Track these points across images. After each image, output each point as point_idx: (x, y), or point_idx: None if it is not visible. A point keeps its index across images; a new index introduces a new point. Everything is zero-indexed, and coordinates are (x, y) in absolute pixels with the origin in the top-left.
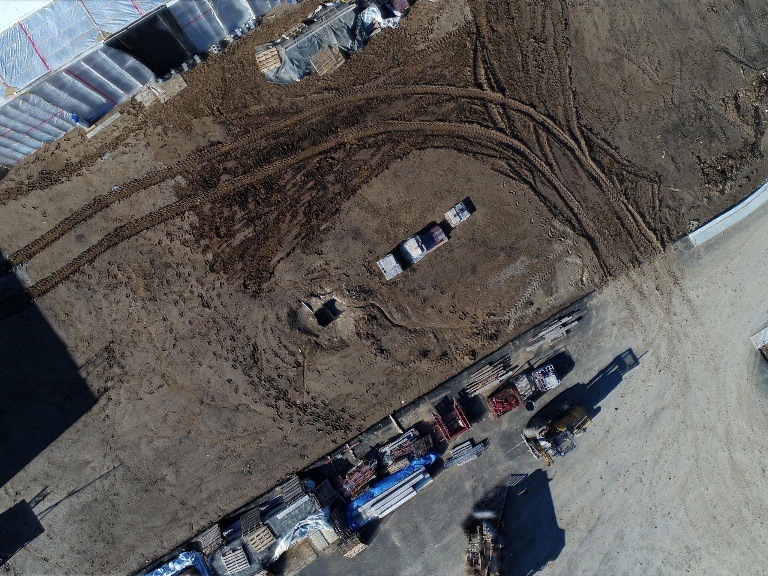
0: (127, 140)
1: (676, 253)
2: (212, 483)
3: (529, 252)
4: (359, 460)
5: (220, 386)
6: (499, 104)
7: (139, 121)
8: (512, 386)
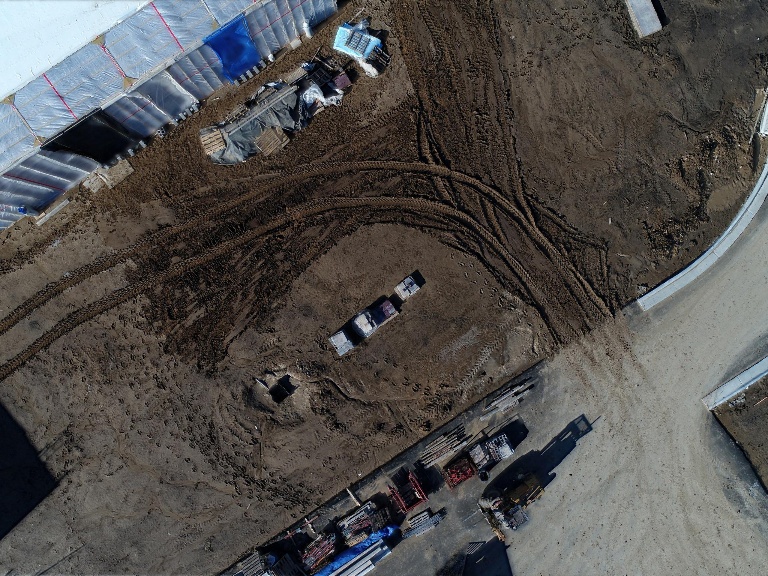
0: (77, 227)
1: (625, 318)
2: (174, 561)
3: (479, 322)
4: (317, 535)
5: (178, 465)
6: (445, 177)
7: (88, 207)
8: (467, 456)
